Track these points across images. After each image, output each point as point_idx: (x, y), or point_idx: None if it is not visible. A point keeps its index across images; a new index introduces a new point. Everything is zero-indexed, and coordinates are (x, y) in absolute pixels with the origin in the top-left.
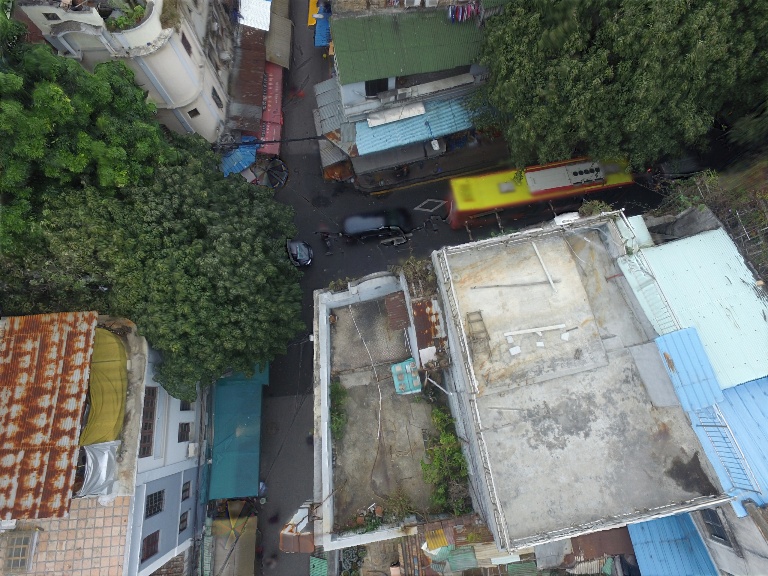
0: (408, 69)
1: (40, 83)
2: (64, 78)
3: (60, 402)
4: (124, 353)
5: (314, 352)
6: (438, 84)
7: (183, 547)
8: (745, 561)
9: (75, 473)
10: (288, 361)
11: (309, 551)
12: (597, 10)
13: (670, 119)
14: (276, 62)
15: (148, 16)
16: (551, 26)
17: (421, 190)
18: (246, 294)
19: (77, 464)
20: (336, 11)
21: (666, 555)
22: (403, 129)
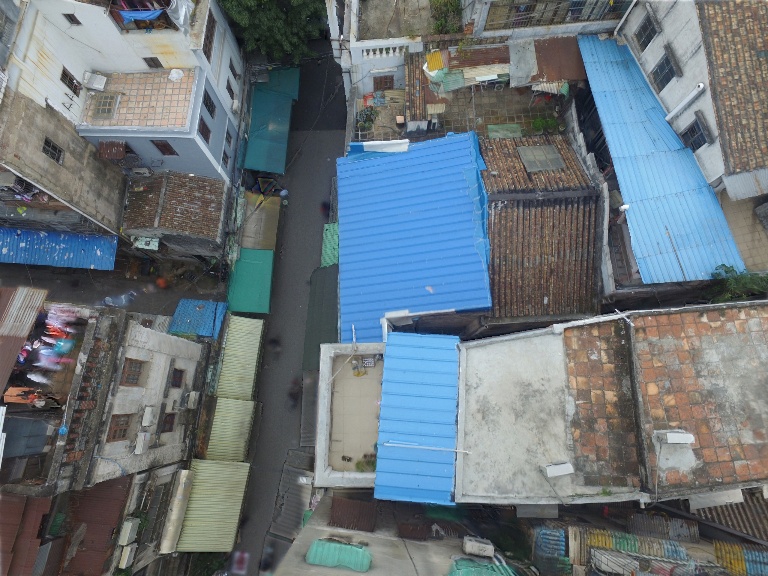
0: None
1: None
2: None
3: None
4: None
5: None
6: None
7: (224, 176)
8: (663, 32)
9: None
10: (313, 105)
11: None
12: None
13: None
14: None
15: None
16: None
17: None
18: None
19: None
20: None
21: (608, 69)
22: None
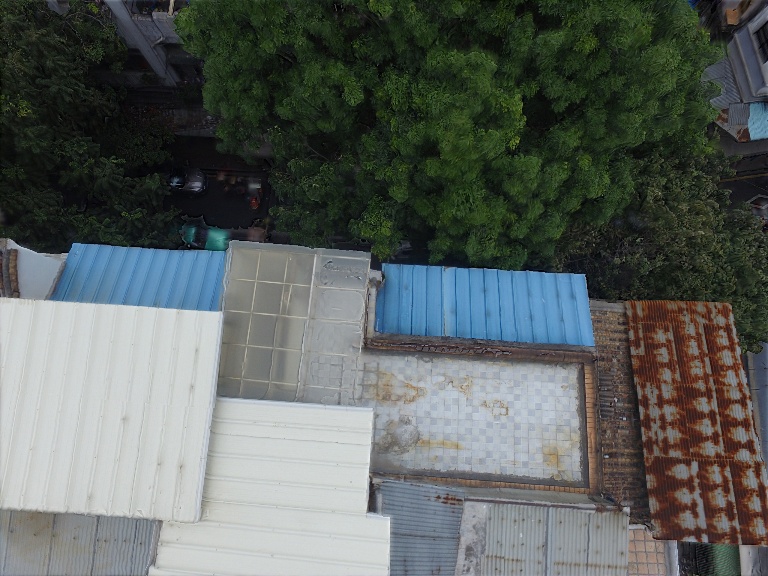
0: None
1: None
2: None
3: (722, 408)
4: None
5: None
6: None
7: None
8: None
9: None
10: None
11: None
12: None
13: None
14: None
15: None
16: None
17: None
18: None
19: None
20: None
21: None
22: None
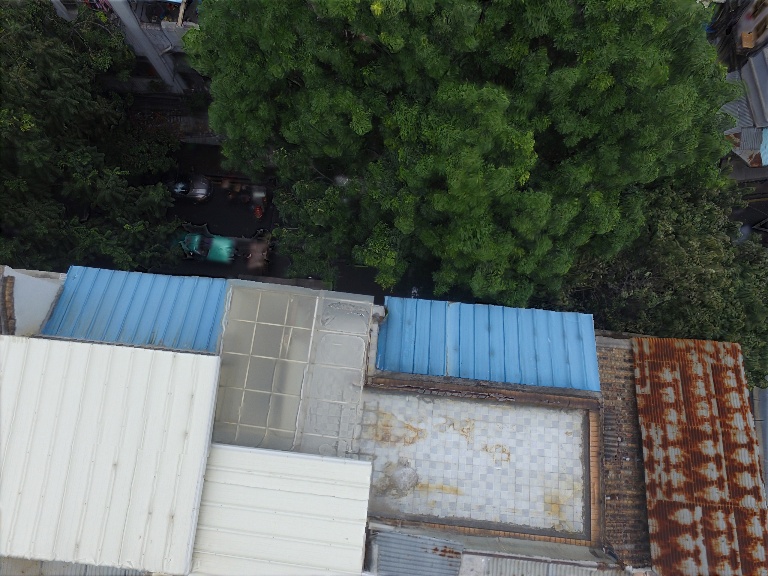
0: None
1: None
2: None
3: (728, 452)
4: None
5: None
6: None
7: None
8: None
9: None
10: None
11: None
12: None
13: None
14: None
15: None
16: None
17: (760, 207)
18: None
19: None
20: None
21: None
22: None
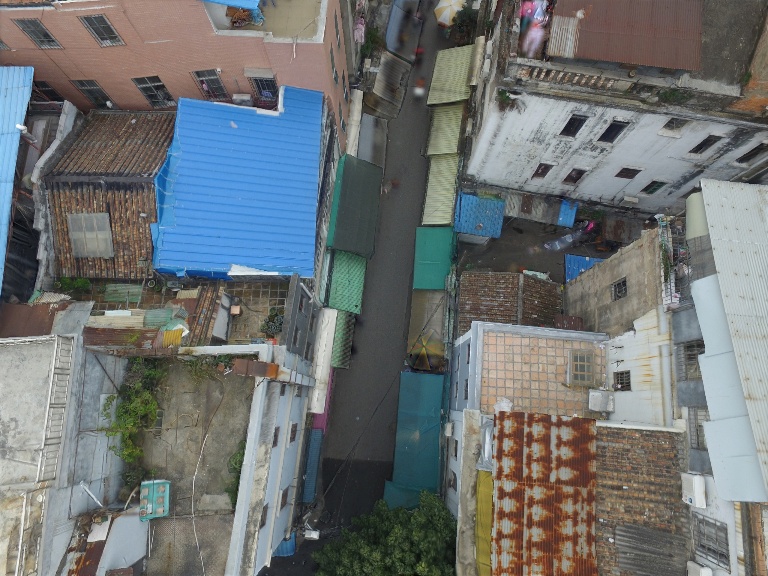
0: None
1: None
2: None
3: (519, 531)
4: None
5: (256, 541)
6: None
7: None
8: None
9: (493, 451)
10: (374, 500)
11: (239, 360)
12: None
13: None
14: None
15: None
16: None
17: None
18: None
19: (494, 460)
20: None
21: None
22: None
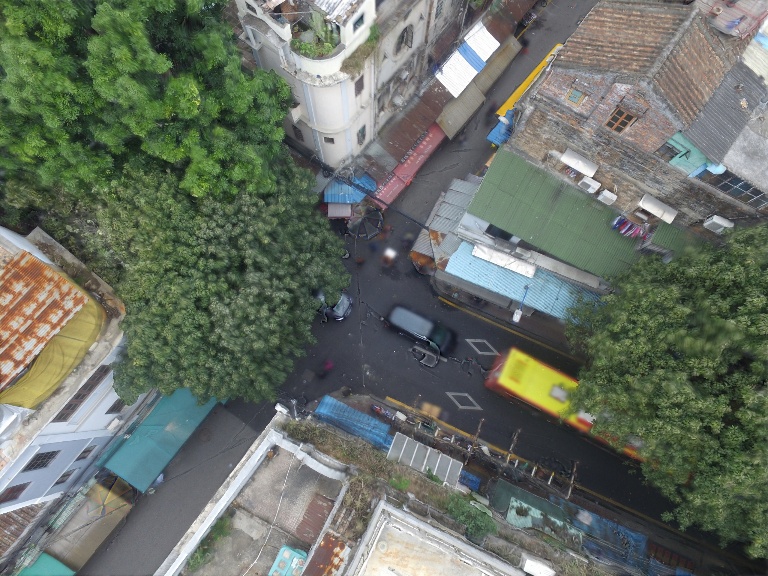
0: (538, 240)
1: (199, 60)
2: (220, 70)
3: (1, 358)
4: (96, 335)
5: (235, 469)
6: (560, 266)
7: (49, 498)
8: None
9: None
10: None
11: None
12: (752, 358)
13: (748, 515)
14: (443, 128)
15: (332, 56)
16: (696, 327)
17: (485, 327)
18: (236, 350)
19: None
20: (512, 144)
21: None
22: (501, 276)
